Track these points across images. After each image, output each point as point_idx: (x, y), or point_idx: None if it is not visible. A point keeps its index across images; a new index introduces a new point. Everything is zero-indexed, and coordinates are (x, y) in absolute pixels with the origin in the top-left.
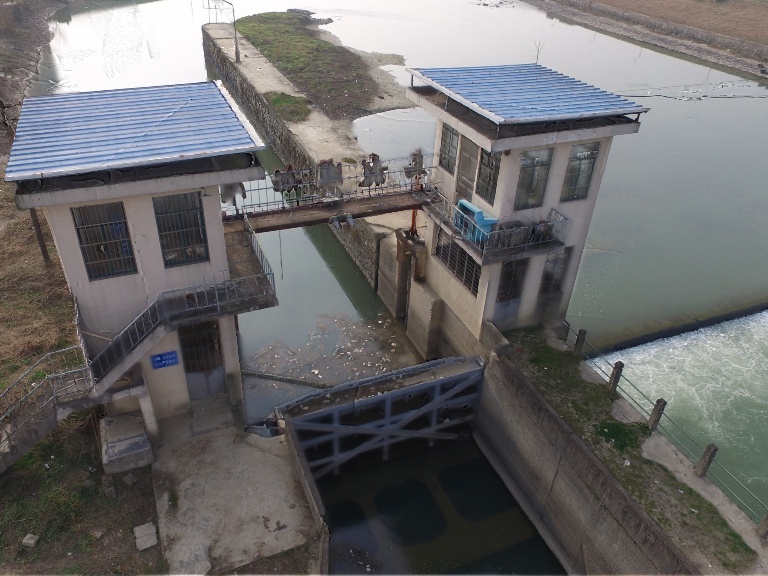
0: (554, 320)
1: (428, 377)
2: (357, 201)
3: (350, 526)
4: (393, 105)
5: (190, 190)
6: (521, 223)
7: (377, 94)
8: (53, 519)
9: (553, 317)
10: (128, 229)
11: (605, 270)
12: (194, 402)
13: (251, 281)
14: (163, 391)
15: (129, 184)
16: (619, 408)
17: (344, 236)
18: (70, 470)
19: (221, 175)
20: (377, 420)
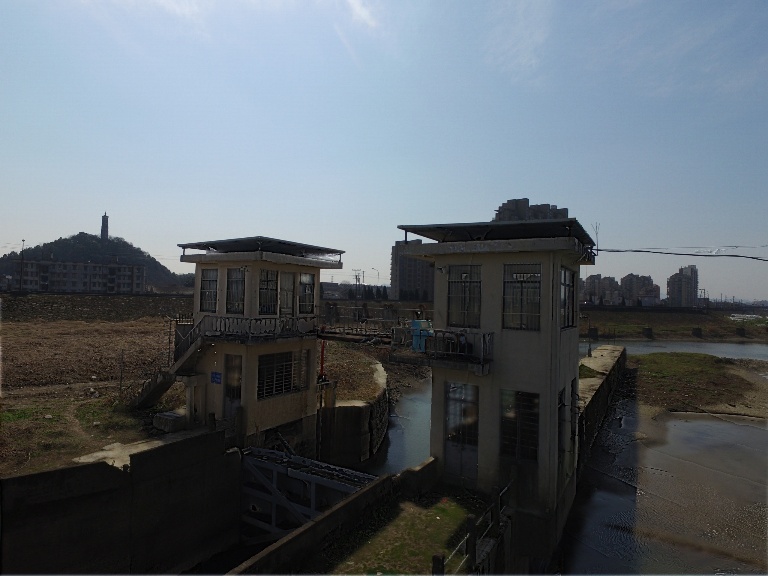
0: (533, 506)
1: (355, 485)
2: None
3: None
4: (740, 412)
5: None
6: (450, 338)
7: (730, 403)
8: None
9: (531, 500)
10: (217, 285)
11: None
12: (224, 421)
13: None
14: (212, 403)
15: None
16: None
17: None
18: None
19: None
20: (305, 506)
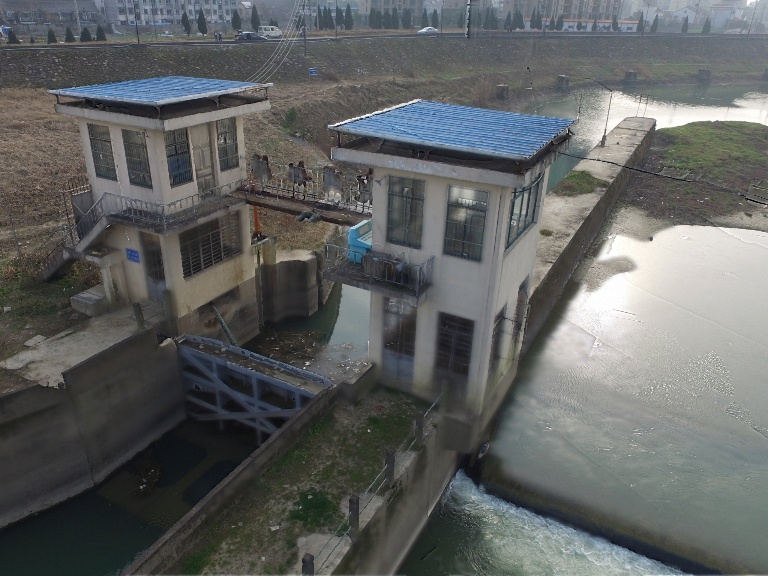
0: (461, 412)
1: (296, 382)
2: (348, 212)
3: (181, 462)
4: (753, 225)
5: (139, 130)
6: (389, 257)
7: (748, 210)
8: (24, 307)
9: (459, 407)
10: (112, 147)
11: (762, 475)
12: (151, 301)
13: (181, 219)
14: (134, 280)
15: (98, 111)
16: (363, 499)
17: None
18: (66, 296)
19: (141, 119)
20: (249, 395)
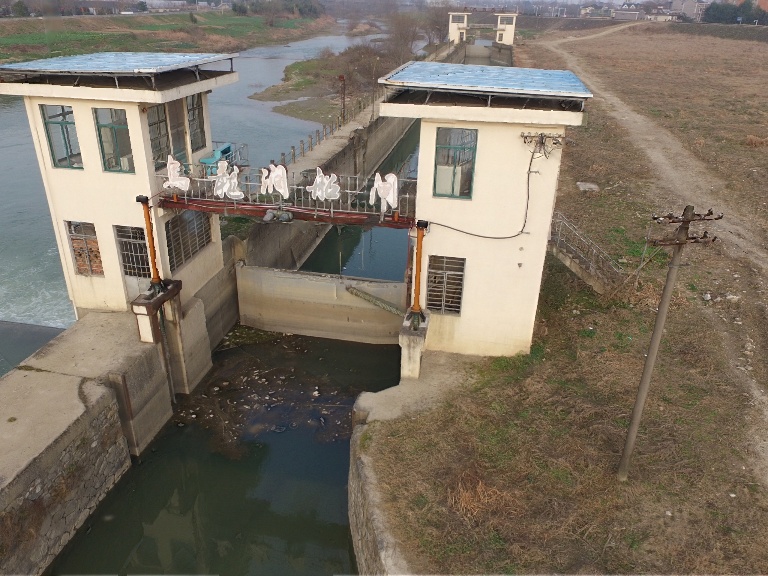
0: None
1: None
2: None
3: None
4: None
5: None
6: None
7: None
8: None
9: None
10: None
11: None
12: None
13: None
14: None
15: None
16: None
17: (25, 569)
18: None
19: None
20: None
